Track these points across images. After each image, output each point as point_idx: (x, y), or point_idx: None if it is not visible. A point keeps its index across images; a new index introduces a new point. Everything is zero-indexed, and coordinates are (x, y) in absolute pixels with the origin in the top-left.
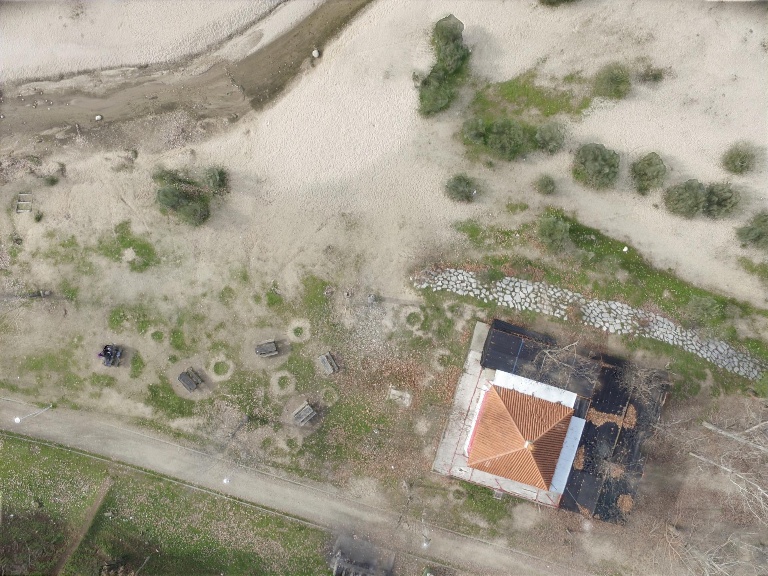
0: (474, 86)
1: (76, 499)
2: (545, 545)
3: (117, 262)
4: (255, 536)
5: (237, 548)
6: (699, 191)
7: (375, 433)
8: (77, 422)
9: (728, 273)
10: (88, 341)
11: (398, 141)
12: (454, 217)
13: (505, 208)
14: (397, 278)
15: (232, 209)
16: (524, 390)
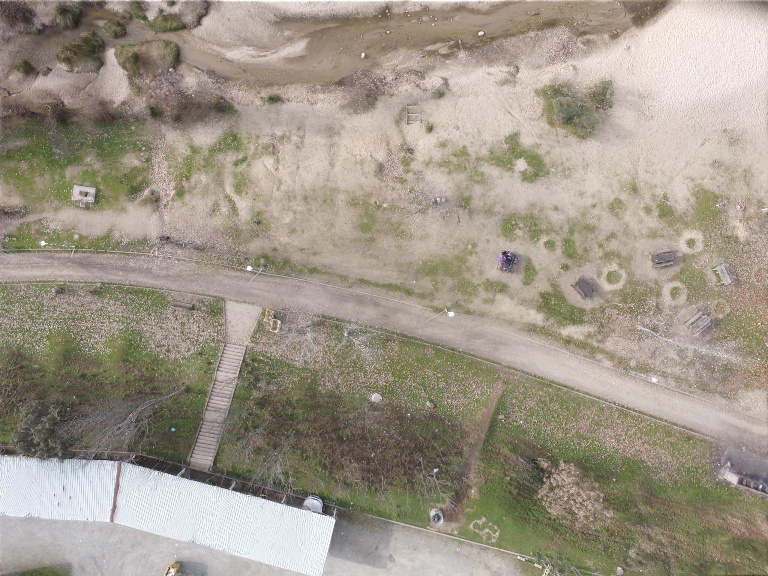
0: None
1: (469, 401)
2: None
3: (509, 172)
4: (643, 444)
5: (625, 455)
6: None
7: (767, 346)
8: (469, 327)
9: None
10: (482, 248)
11: None
12: None
13: None
14: None
15: (615, 123)
16: None
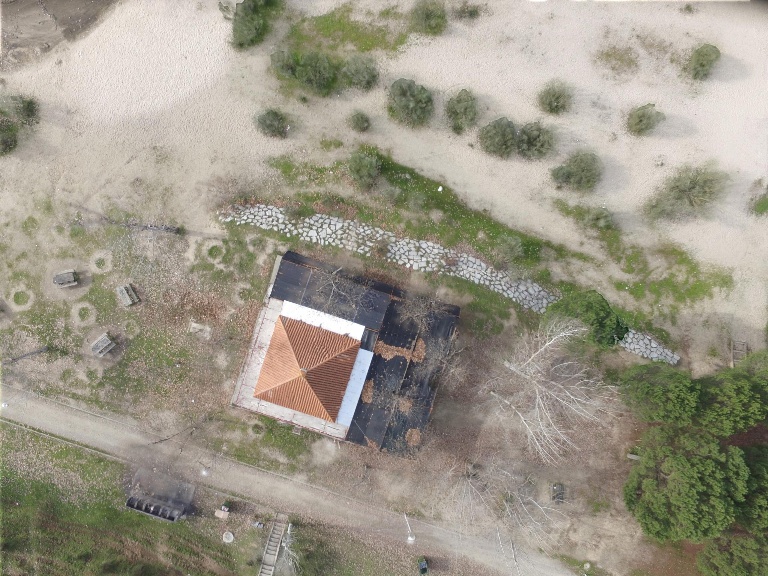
0: (288, 20)
1: None
2: (344, 481)
3: None
4: (54, 467)
5: (35, 479)
6: (507, 129)
7: (176, 366)
8: None
9: (543, 215)
10: None
11: (211, 74)
12: (267, 153)
13: (319, 145)
14: (204, 212)
15: (40, 140)
16: (311, 321)
